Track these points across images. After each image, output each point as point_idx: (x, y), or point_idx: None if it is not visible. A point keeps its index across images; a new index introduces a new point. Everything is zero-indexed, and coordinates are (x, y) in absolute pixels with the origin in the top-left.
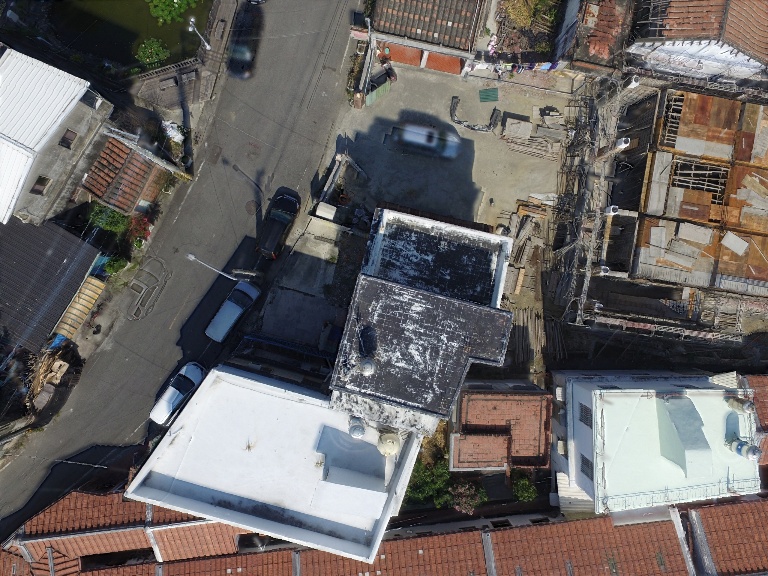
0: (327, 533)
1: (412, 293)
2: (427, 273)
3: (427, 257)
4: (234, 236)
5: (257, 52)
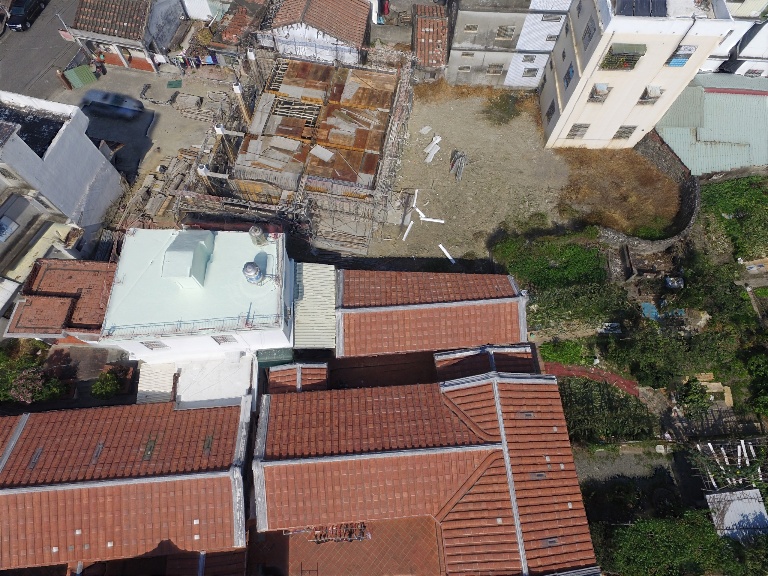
0: None
1: None
2: None
3: None
4: None
5: (5, 57)
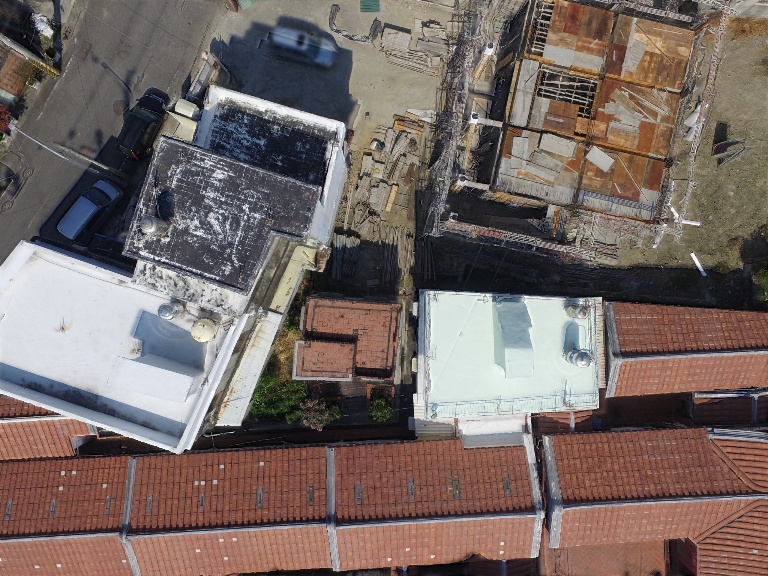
0: (141, 424)
1: (214, 159)
2: (258, 158)
3: (259, 141)
4: (100, 136)
5: None
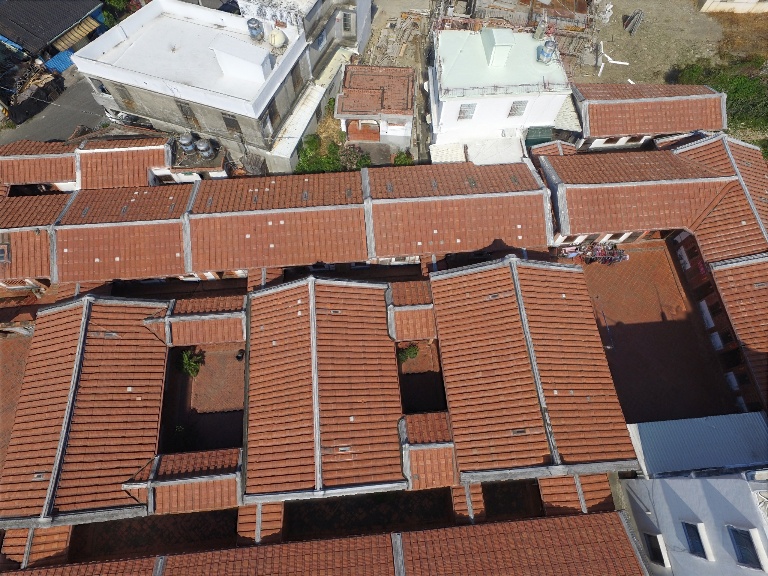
0: None
1: None
2: None
3: None
4: None
5: None
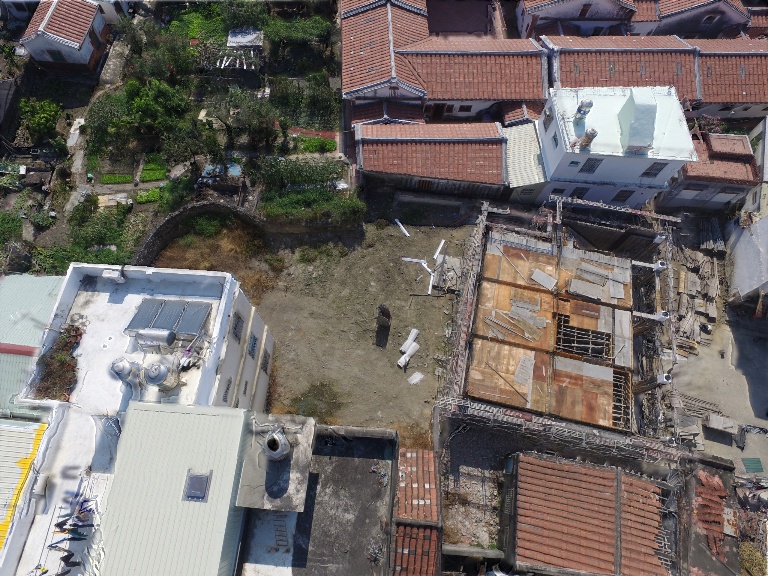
0: None
1: None
2: None
3: None
4: None
5: None
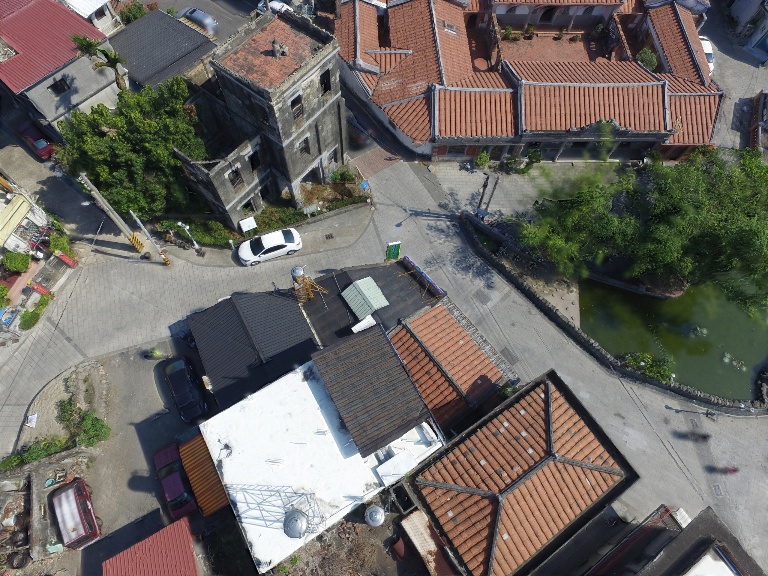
0: None
1: None
2: None
3: None
4: None
5: None
